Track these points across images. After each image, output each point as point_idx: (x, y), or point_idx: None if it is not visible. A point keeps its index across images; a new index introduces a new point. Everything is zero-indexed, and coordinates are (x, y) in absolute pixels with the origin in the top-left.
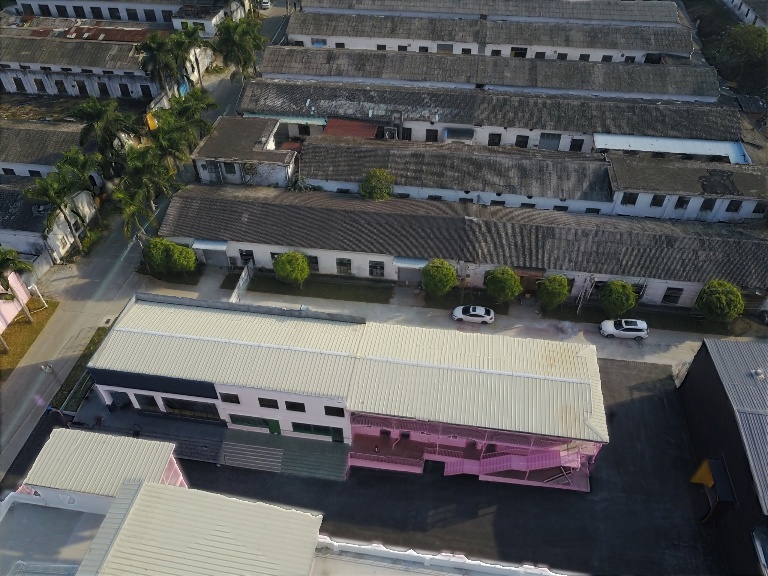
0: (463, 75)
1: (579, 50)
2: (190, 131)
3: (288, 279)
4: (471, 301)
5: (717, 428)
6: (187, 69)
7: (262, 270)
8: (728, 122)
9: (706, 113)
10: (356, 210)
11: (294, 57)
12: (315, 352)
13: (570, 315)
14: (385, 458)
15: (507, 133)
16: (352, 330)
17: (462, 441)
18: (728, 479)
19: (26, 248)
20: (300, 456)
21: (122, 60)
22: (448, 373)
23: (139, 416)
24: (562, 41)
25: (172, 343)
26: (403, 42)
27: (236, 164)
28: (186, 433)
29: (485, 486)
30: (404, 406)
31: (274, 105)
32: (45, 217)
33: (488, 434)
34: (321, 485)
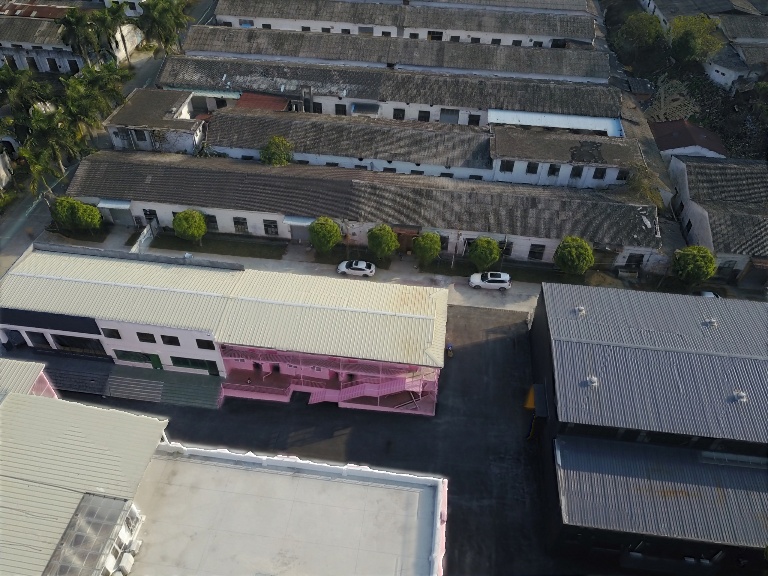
0: (375, 55)
1: (491, 35)
2: (99, 99)
3: (186, 235)
4: (357, 257)
5: (544, 358)
6: (111, 45)
7: (166, 229)
8: (610, 100)
9: (591, 92)
10: (253, 173)
11: (217, 35)
12: (192, 293)
13: (445, 270)
14: (254, 387)
15: (410, 108)
16: (231, 275)
17: (326, 373)
18: (545, 399)
19: None
20: (179, 388)
21: (51, 36)
22: (310, 311)
23: (33, 354)
24: (475, 26)
25: (61, 285)
26: (326, 24)
27: (146, 131)
28: (76, 368)
29: (343, 412)
30: (266, 338)
31: (192, 79)
32: None
33: (342, 363)
34: (196, 412)
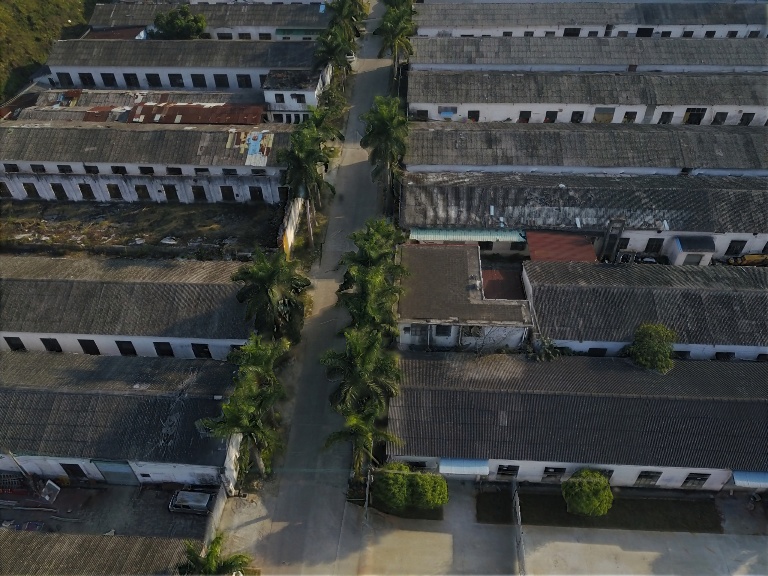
0: (665, 157)
1: None
2: (403, 293)
3: None
4: None
5: None
6: (316, 167)
7: (523, 484)
8: None
9: None
10: (656, 398)
11: (444, 141)
12: None
13: None
14: None
15: (755, 239)
16: None
17: None
18: None
19: (187, 478)
20: None
21: (219, 153)
22: None
23: None
24: (749, 99)
25: None
26: (553, 107)
27: (455, 326)
28: None
29: None
30: None
31: (449, 216)
32: (219, 439)
33: None
34: None
